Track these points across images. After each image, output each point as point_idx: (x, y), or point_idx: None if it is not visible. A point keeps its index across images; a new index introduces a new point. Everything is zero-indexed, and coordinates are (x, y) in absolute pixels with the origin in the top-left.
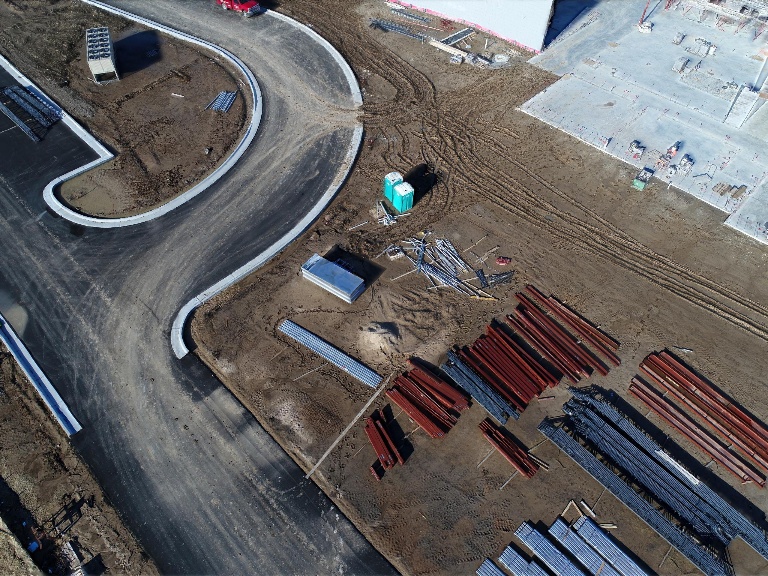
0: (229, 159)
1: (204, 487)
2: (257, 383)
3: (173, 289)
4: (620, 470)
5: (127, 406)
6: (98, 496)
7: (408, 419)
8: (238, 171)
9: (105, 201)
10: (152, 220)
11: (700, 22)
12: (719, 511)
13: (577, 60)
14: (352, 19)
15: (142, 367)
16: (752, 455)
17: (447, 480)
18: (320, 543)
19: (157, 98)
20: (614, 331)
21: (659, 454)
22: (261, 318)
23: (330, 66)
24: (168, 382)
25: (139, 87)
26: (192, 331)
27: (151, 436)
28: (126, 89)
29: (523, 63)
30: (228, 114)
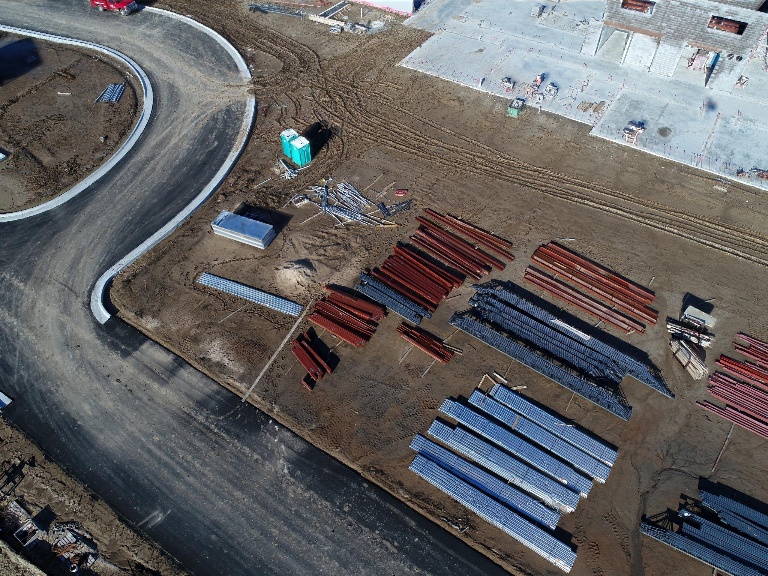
0: (126, 143)
1: (144, 428)
2: (183, 331)
3: (86, 265)
4: (524, 342)
5: (56, 373)
6: (38, 456)
7: (331, 336)
8: (137, 153)
9: (3, 198)
10: (55, 208)
11: None
12: (609, 357)
13: (446, 17)
14: (231, 6)
15: (66, 337)
16: (632, 310)
17: (373, 379)
18: (263, 452)
19: (43, 99)
20: (506, 234)
21: (554, 322)
22: (179, 276)
23: (215, 49)
24: (94, 346)
25: (22, 91)
26: (112, 298)
27: (84, 395)
28: (9, 94)
29: (398, 26)
30: (119, 104)
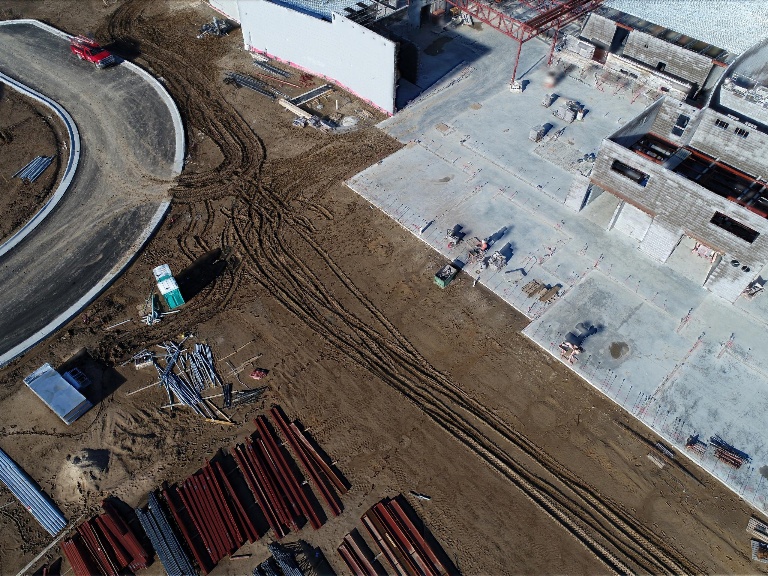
0: (12, 239)
1: None
2: None
3: None
4: None
5: None
6: None
7: None
8: (16, 253)
9: None
10: None
11: (581, 80)
12: None
13: (430, 125)
14: (209, 72)
15: None
16: None
17: None
18: None
19: None
20: (350, 469)
21: None
22: None
23: (164, 128)
24: None
25: None
26: None
27: None
28: None
29: (370, 127)
30: (34, 184)
